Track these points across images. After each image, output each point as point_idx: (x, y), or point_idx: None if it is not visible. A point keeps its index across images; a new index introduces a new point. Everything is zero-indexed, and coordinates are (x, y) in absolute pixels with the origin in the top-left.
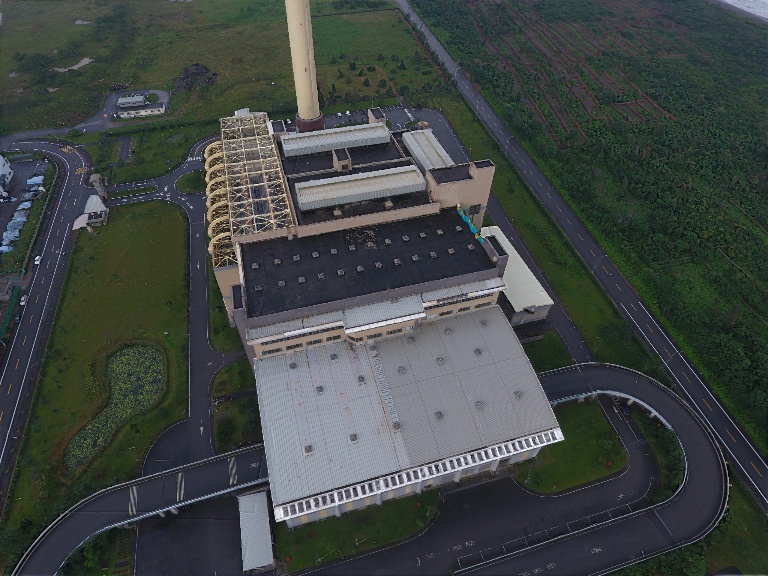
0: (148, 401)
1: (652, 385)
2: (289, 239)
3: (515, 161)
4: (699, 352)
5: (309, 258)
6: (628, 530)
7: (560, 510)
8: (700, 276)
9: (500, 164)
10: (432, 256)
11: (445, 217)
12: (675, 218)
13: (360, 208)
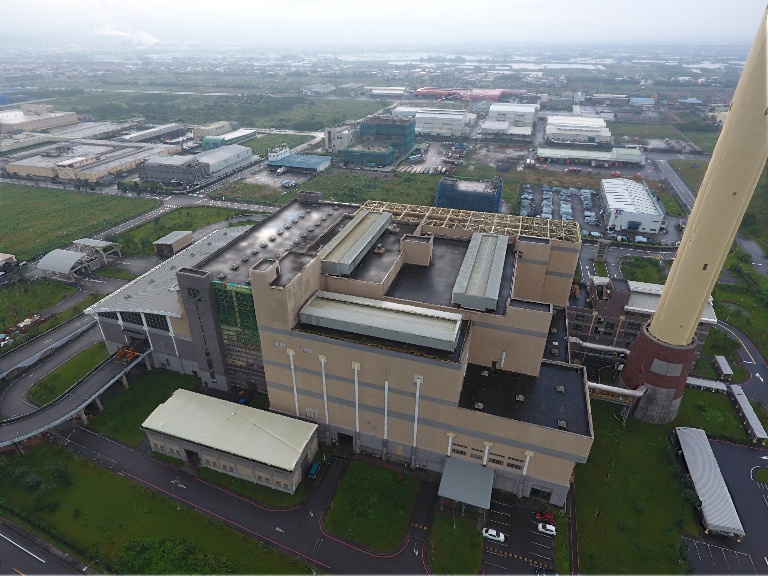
0: None
1: None
2: None
3: None
4: None
5: None
6: (24, 357)
7: (80, 345)
8: None
9: None
10: None
11: None
12: None
13: None
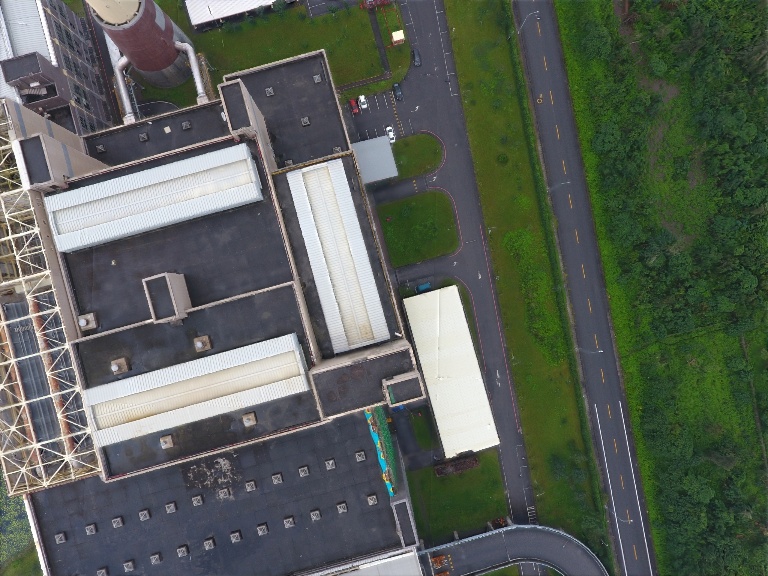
0: (21, 542)
1: (580, 551)
2: (102, 479)
3: (530, 62)
4: (659, 486)
5: (136, 520)
6: None
7: None
8: (723, 358)
9: (500, 77)
10: (313, 520)
11: (343, 426)
12: (741, 251)
13: (203, 426)
